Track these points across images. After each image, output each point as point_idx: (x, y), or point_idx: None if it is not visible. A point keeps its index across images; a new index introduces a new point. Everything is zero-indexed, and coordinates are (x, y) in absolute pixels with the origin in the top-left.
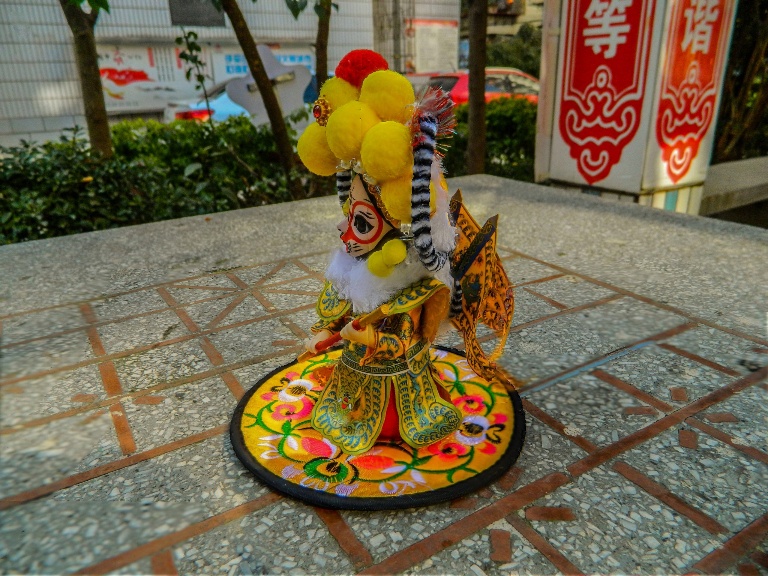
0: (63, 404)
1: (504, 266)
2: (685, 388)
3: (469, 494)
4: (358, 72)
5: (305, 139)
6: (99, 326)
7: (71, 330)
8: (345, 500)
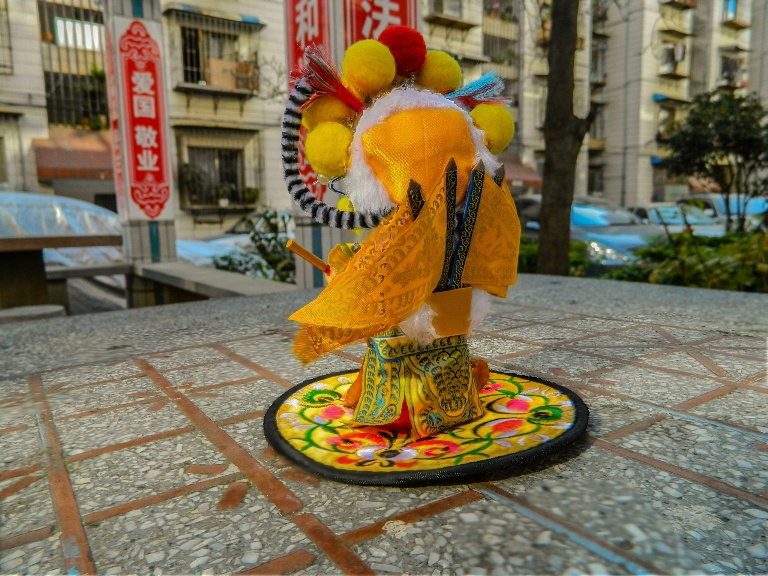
0: None
1: None
2: None
3: (276, 452)
4: None
5: None
6: (542, 324)
7: (530, 321)
8: (277, 402)
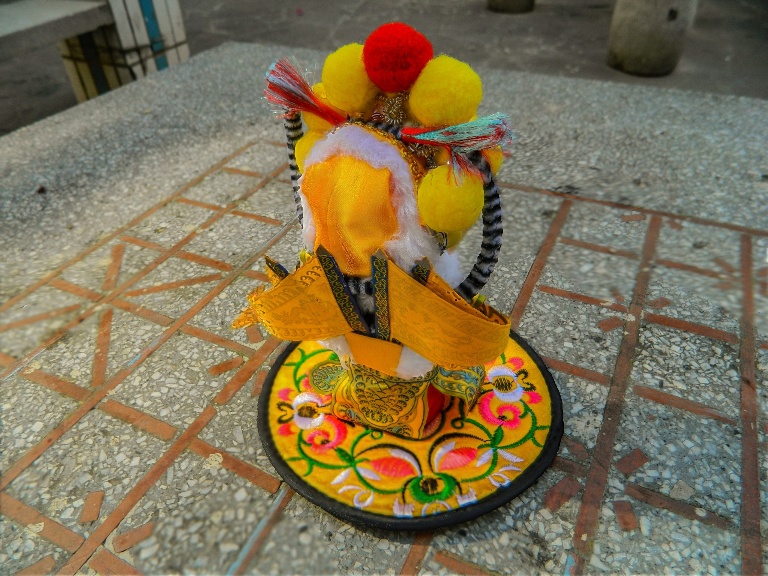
0: (660, 292)
1: None
2: None
3: None
4: None
5: None
6: None
7: None
8: None
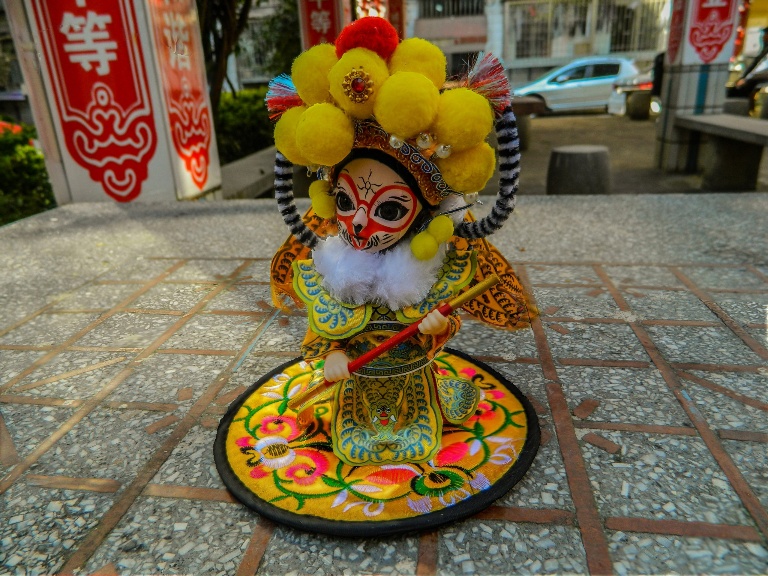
0: None
1: (256, 272)
2: None
3: None
4: (387, 41)
5: (323, 123)
6: None
7: None
8: (498, 488)
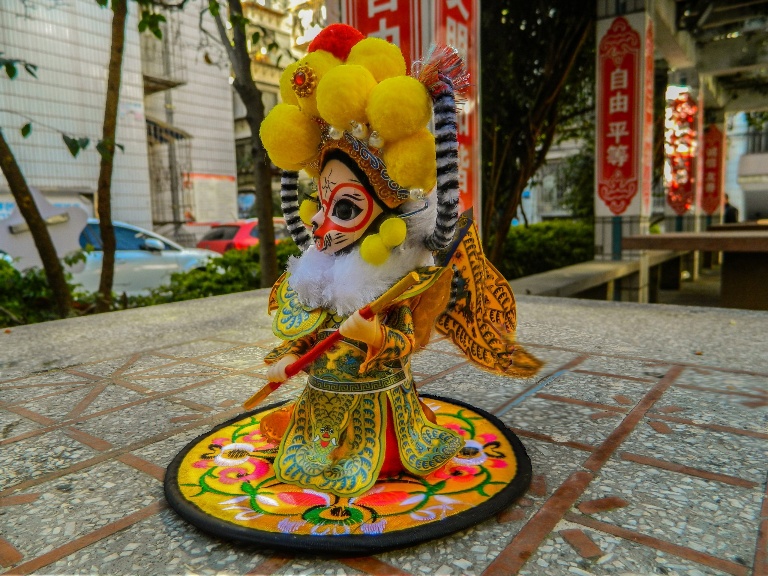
0: None
1: None
2: (623, 395)
3: (512, 505)
4: (343, 42)
5: (275, 117)
6: None
7: None
8: (383, 536)
